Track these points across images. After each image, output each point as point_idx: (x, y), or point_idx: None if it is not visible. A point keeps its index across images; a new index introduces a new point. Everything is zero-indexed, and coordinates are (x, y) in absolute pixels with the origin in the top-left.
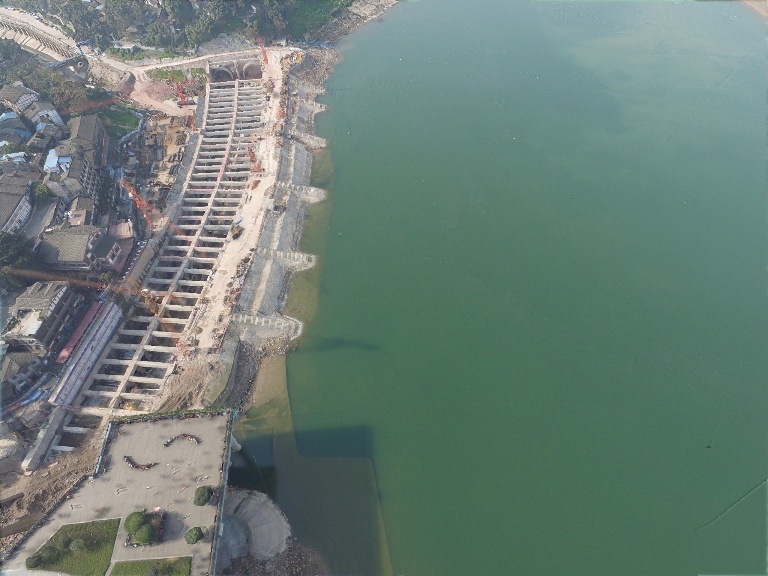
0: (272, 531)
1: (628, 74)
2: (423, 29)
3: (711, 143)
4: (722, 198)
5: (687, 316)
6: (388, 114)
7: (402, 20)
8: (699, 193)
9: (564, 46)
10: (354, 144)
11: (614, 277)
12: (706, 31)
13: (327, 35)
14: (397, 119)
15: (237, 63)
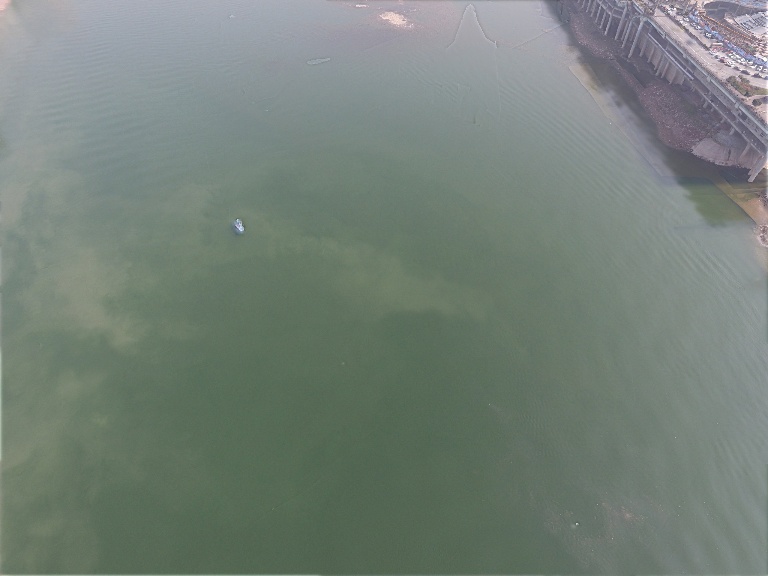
0: (704, 148)
1: None
2: None
3: (199, 507)
4: (291, 368)
5: (428, 234)
6: None
7: None
8: (313, 380)
9: None
10: None
11: (476, 269)
12: None
13: None
14: None
15: None
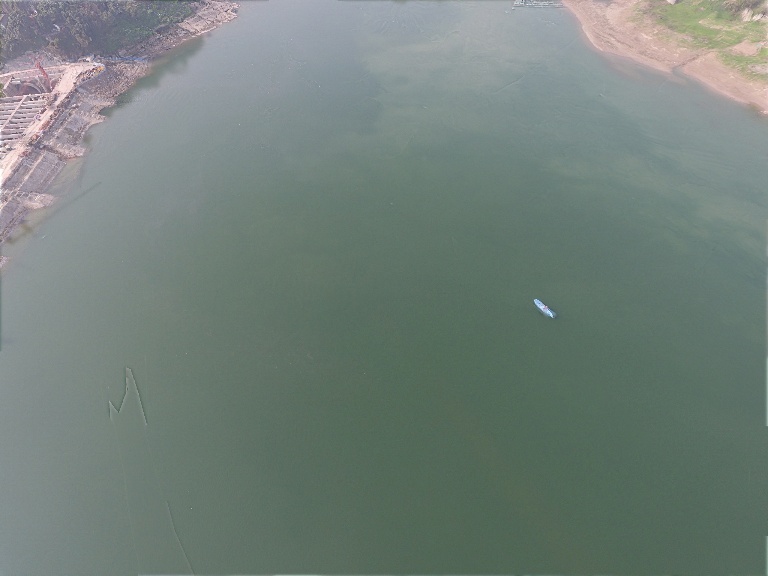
0: None
1: (418, 81)
2: (242, 43)
3: (456, 146)
4: (430, 199)
5: (317, 311)
6: (160, 124)
7: (229, 34)
8: (411, 194)
9: (365, 56)
10: (110, 153)
11: (273, 275)
12: (518, 38)
13: (147, 50)
14: (166, 128)
15: (40, 79)
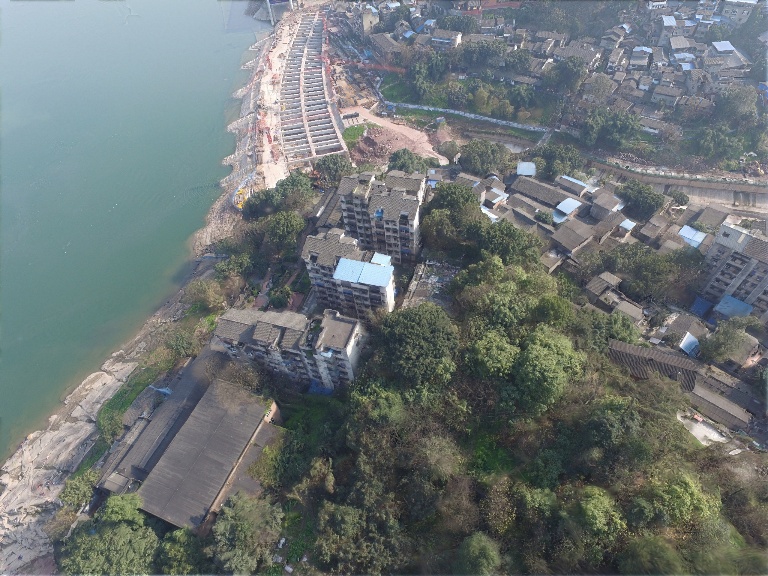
0: None
1: None
2: (26, 326)
3: None
4: None
5: None
6: (161, 163)
7: (44, 367)
8: None
9: None
10: (203, 131)
11: (82, 78)
12: None
13: None
14: (155, 158)
15: None
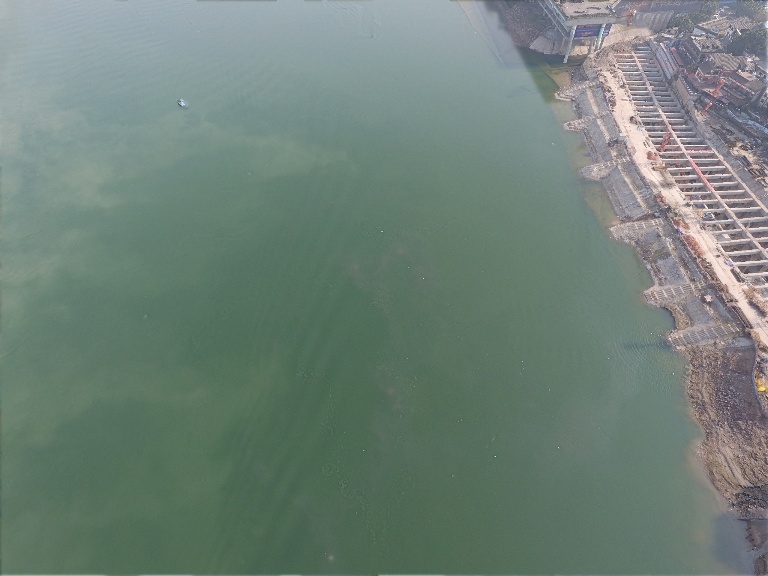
0: None
1: (115, 404)
2: None
3: (148, 244)
4: (213, 177)
5: (320, 102)
6: (546, 286)
7: None
8: (228, 182)
9: (184, 488)
10: (576, 233)
11: (350, 120)
12: None
13: None
14: (531, 276)
15: None
